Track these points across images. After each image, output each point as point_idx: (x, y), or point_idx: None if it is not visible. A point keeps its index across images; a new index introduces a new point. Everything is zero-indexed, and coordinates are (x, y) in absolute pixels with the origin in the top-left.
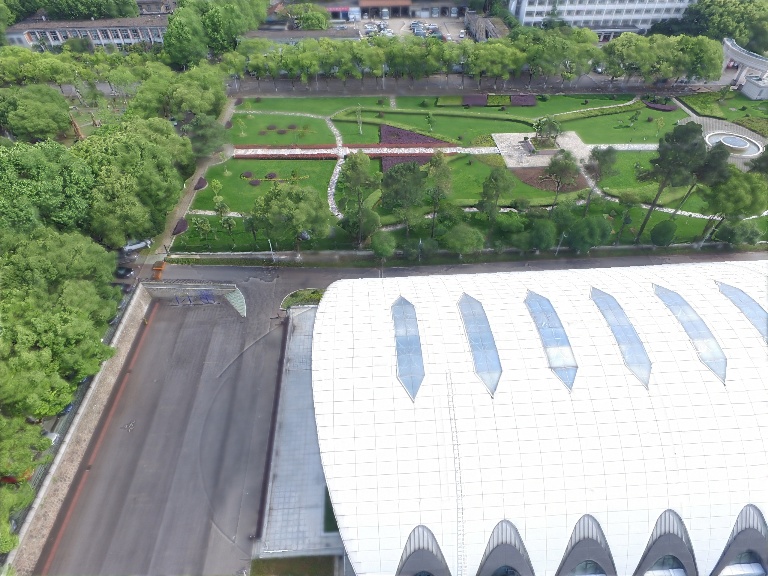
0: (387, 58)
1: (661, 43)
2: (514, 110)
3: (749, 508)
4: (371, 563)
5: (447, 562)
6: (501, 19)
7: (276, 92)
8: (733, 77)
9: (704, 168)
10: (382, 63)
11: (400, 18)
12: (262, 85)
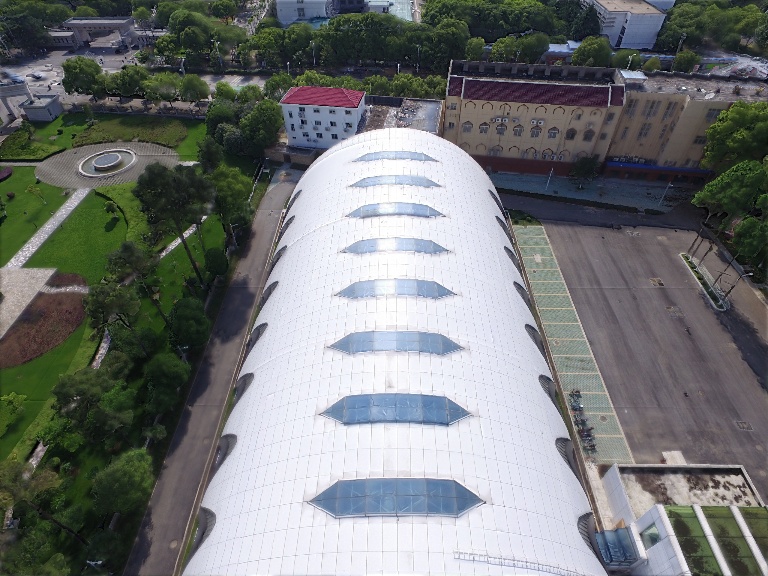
0: None
1: None
2: None
3: (526, 329)
4: None
5: None
6: None
7: None
8: (4, 113)
9: None
10: None
11: None
12: None
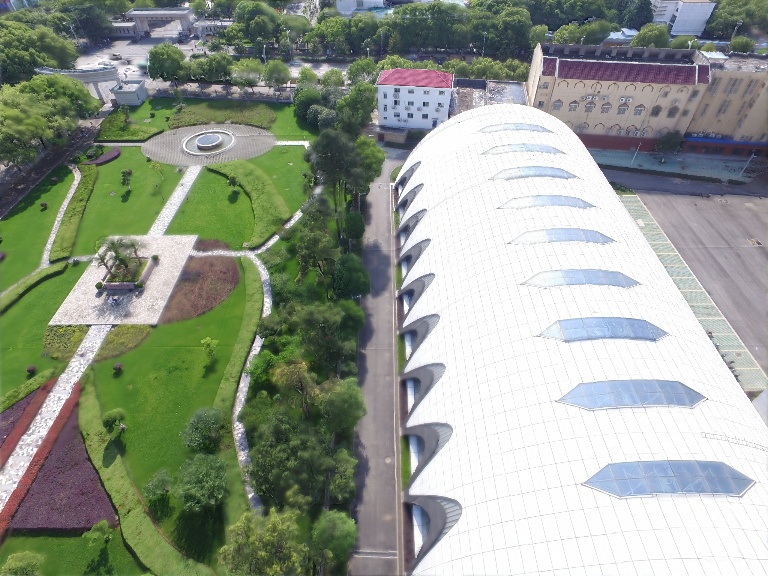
0: None
1: (25, 101)
2: None
3: None
4: None
5: None
6: None
7: None
8: None
9: None
10: None
11: None
12: None
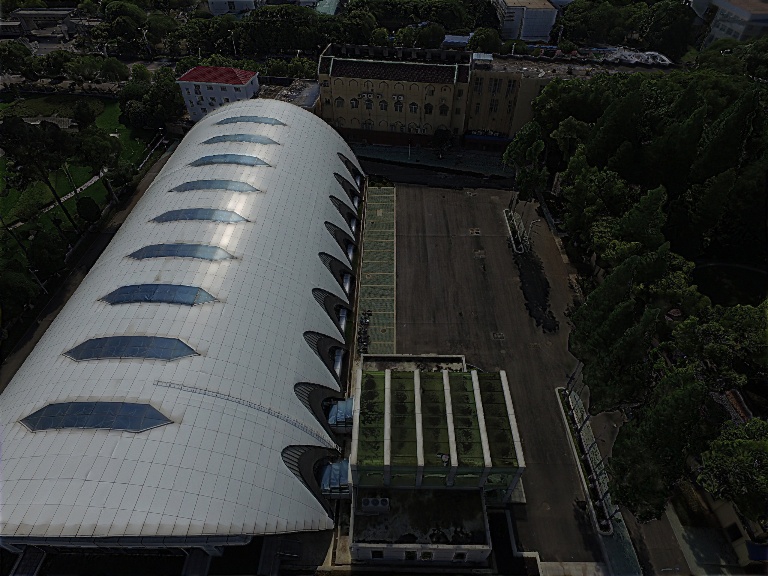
0: None
1: None
2: None
3: (320, 256)
4: (299, 511)
5: (311, 445)
6: None
7: None
8: None
9: (55, 145)
10: None
11: None
12: None
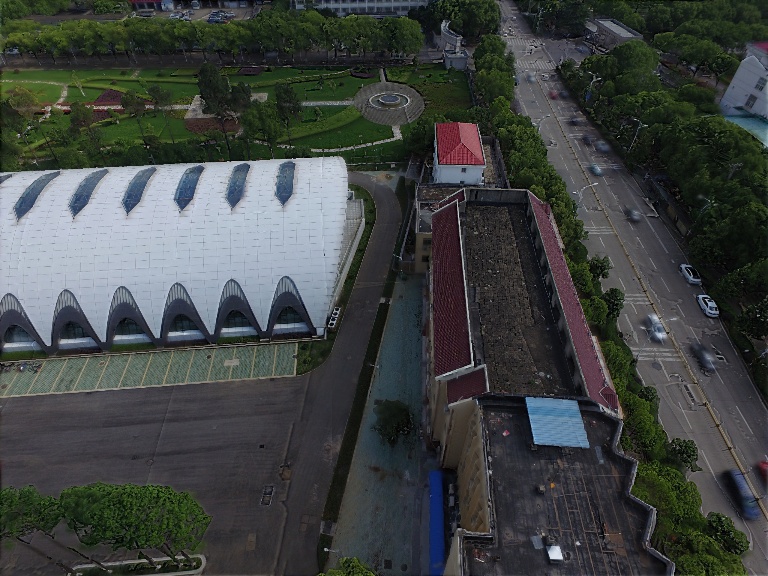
0: (132, 36)
1: (361, 22)
2: (235, 78)
3: (67, 293)
4: None
5: None
6: (271, 6)
7: (40, 66)
8: None
9: None
10: (125, 40)
11: (211, 8)
12: (32, 61)
